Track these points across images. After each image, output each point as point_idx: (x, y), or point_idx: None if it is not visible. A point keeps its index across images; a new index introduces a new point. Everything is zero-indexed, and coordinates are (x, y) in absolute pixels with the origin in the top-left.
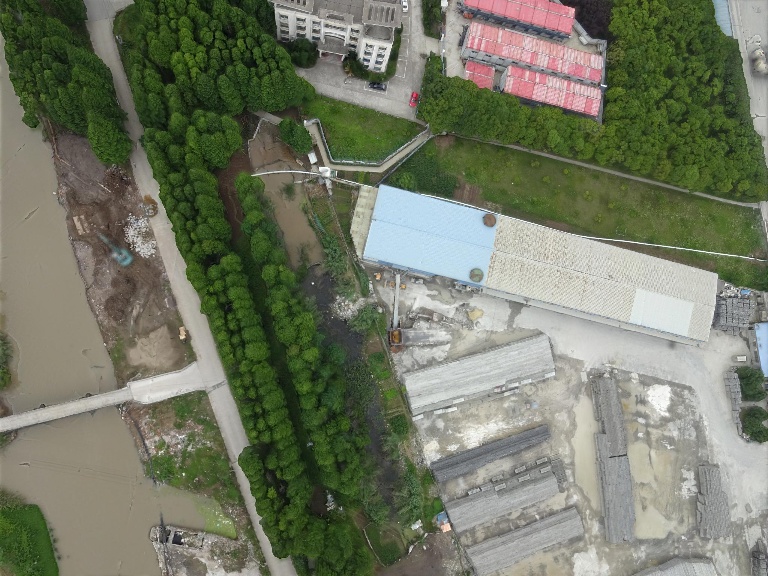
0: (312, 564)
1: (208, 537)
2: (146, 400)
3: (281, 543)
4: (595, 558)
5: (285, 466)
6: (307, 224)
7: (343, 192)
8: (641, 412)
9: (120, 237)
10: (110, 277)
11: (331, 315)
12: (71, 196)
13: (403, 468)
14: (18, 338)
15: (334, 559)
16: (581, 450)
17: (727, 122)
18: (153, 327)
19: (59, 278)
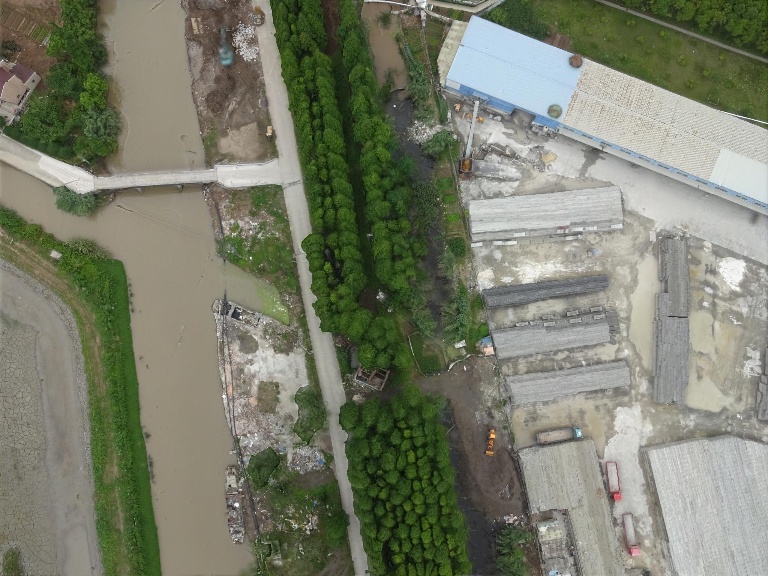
0: (355, 364)
1: (264, 317)
2: (228, 184)
3: (330, 313)
4: (639, 416)
5: (344, 245)
6: (397, 52)
7: (436, 26)
8: (710, 282)
9: (228, 41)
10: (214, 74)
11: (407, 137)
12: (192, 1)
13: (455, 290)
14: (128, 123)
15: (377, 335)
16: (639, 307)
17: None
18: (244, 123)
19: (171, 73)
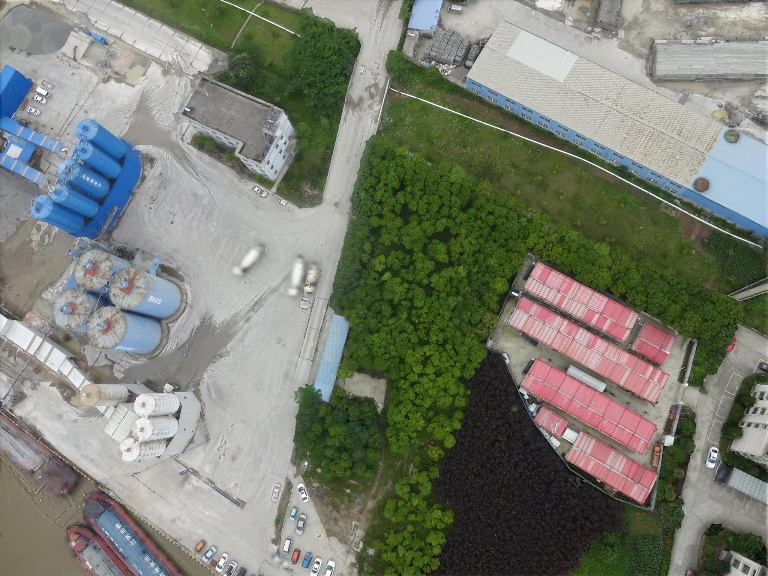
0: None
1: None
2: None
3: None
4: None
5: None
6: None
7: None
8: None
9: None
10: None
11: None
12: None
13: None
14: None
15: None
16: None
17: (390, 219)
18: None
19: None
